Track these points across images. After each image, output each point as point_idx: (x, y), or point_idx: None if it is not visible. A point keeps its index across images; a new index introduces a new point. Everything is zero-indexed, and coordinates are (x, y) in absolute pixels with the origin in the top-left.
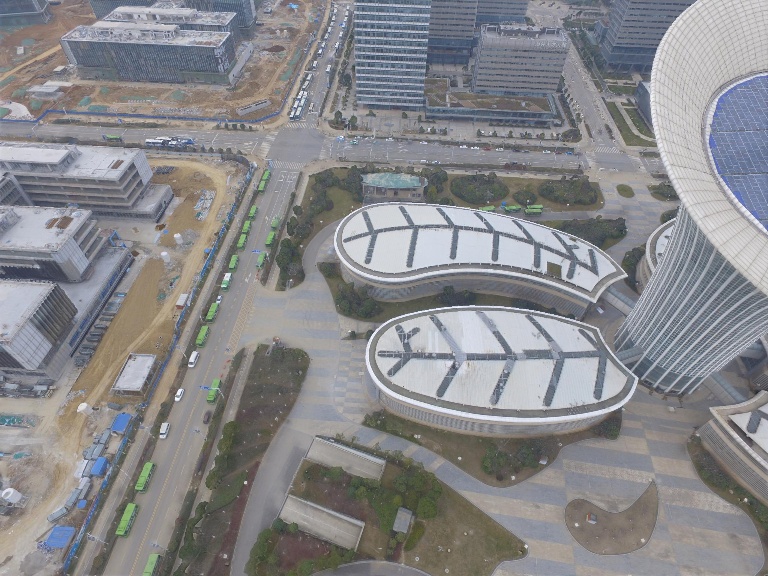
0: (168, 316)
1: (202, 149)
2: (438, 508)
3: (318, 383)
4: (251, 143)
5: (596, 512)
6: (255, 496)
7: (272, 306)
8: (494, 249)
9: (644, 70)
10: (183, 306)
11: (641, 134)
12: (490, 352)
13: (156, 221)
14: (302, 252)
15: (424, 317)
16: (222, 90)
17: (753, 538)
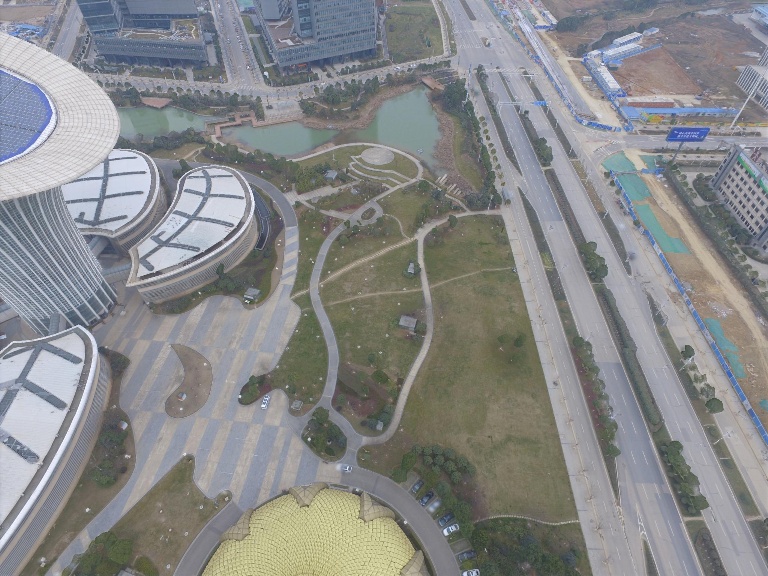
0: None
1: None
2: None
3: None
4: None
5: None
6: None
7: None
8: None
9: None
10: None
11: None
12: None
13: None
14: None
15: None
16: None
17: (224, 299)
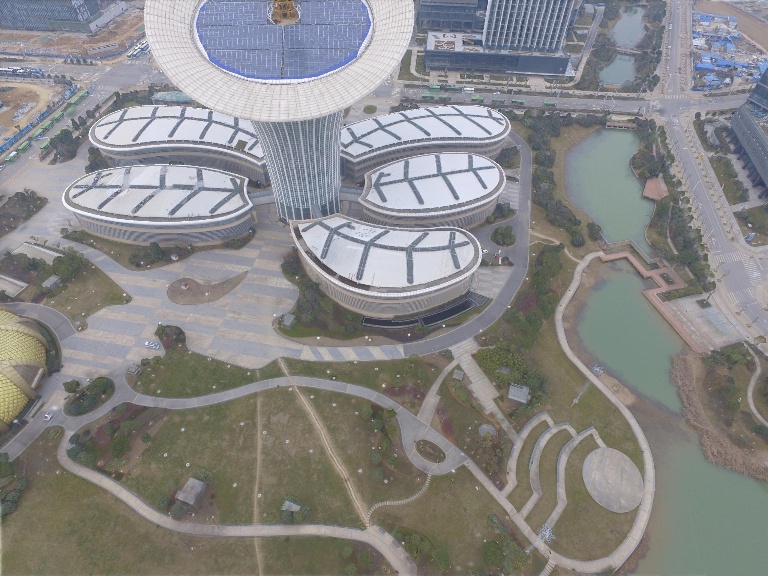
0: None
1: (42, 76)
2: (84, 279)
3: (45, 215)
4: (87, 73)
5: (193, 284)
6: None
7: (39, 173)
8: (204, 131)
9: (452, 26)
10: None
11: (416, 72)
12: (148, 185)
13: None
14: (82, 142)
15: (122, 169)
16: (83, 36)
17: (292, 300)
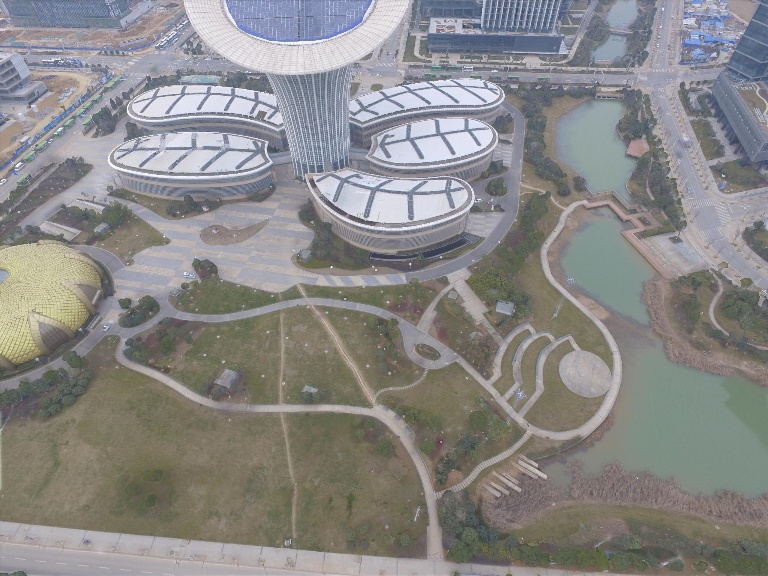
0: (14, 148)
1: (80, 65)
2: (128, 226)
3: (92, 178)
4: (120, 63)
5: (222, 229)
6: (25, 221)
7: (84, 145)
8: (228, 104)
9: (454, 14)
10: (24, 142)
11: (419, 55)
12: (182, 147)
13: (29, 103)
14: (120, 119)
15: (158, 135)
16: (115, 31)
17: (308, 240)
